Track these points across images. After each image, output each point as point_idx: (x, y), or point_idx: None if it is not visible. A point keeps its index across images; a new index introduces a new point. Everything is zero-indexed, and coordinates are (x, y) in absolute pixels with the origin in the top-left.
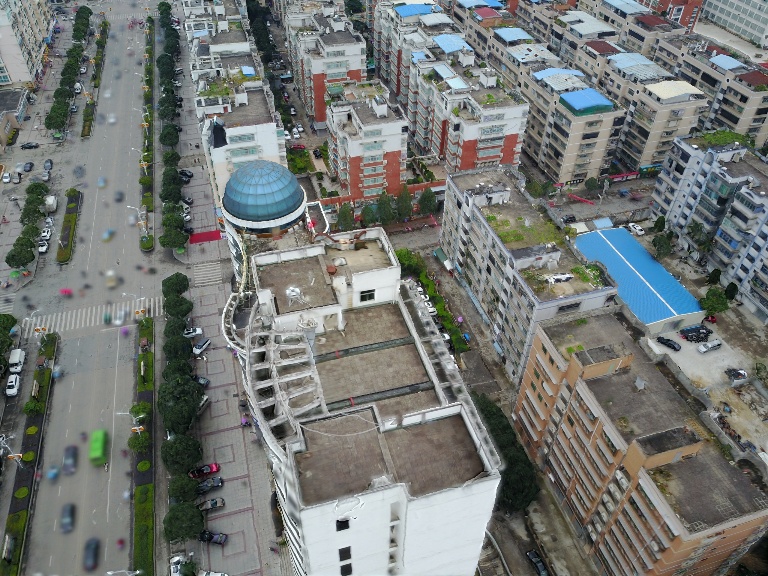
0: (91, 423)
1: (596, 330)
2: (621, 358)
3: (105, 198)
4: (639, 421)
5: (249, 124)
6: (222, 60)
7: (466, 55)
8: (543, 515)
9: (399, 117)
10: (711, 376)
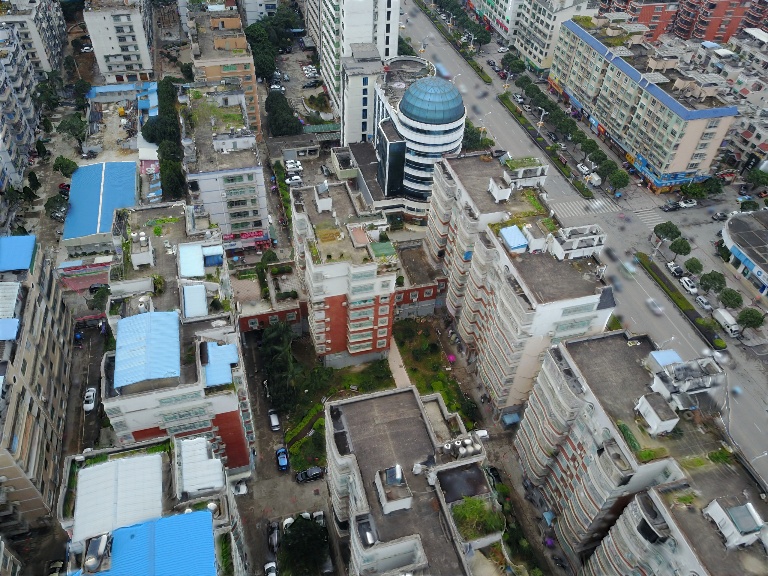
0: (519, 154)
1: (219, 57)
2: (222, 35)
3: (675, 340)
4: (227, 33)
5: (473, 163)
6: (580, 293)
7: (146, 296)
8: (264, 112)
9: (299, 203)
10: (108, 157)
